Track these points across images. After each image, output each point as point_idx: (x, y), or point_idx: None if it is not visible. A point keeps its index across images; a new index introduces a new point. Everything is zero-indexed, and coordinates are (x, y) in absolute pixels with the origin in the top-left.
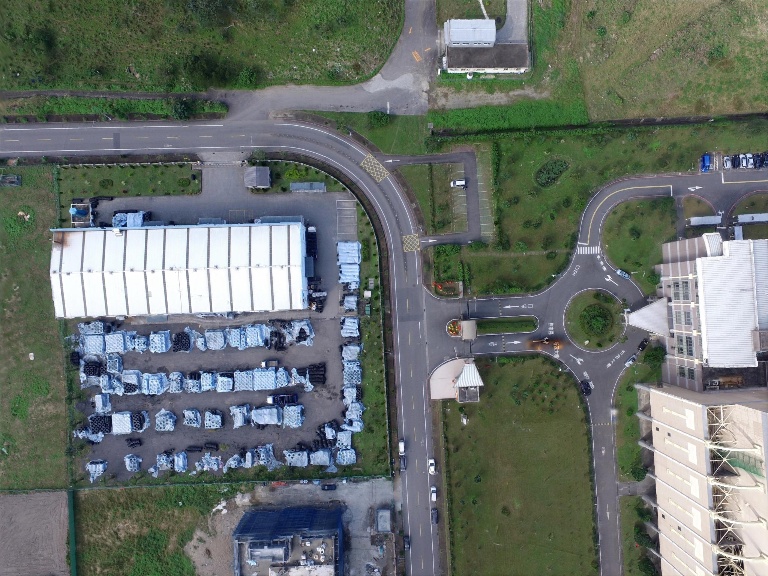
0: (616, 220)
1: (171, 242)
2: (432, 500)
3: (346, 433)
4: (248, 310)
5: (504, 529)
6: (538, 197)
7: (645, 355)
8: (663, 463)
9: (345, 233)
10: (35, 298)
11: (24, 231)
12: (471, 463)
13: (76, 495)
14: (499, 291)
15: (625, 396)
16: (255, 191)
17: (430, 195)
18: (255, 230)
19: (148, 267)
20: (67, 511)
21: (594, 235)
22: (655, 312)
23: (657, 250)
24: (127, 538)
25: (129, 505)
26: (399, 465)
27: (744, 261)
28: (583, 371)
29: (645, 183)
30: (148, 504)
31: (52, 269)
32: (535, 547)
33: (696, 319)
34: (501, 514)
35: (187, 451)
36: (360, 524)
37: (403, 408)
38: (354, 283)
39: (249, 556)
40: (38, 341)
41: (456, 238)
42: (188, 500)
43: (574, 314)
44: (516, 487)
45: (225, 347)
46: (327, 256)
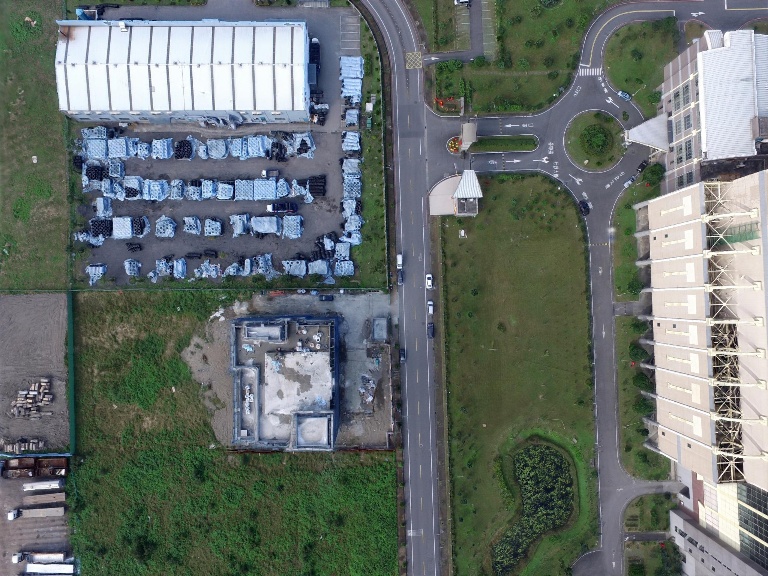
0: (618, 42)
1: (176, 39)
2: (429, 313)
3: (345, 244)
4: (250, 109)
5: (500, 345)
6: (541, 17)
7: (644, 172)
8: (660, 269)
9: (348, 48)
10: (39, 102)
11: (30, 36)
12: (468, 279)
13: (75, 297)
14: (500, 108)
15: (623, 217)
16: (260, 3)
17: (434, 12)
18: (259, 30)
19: (152, 61)
20: (66, 312)
21: (596, 57)
22: (655, 126)
23: (659, 73)
24: (125, 341)
25: (128, 309)
26: (397, 279)
27: (745, 51)
28: (582, 191)
29: (648, 7)
30: (146, 308)
31: (57, 60)
32: (530, 364)
33: (696, 118)
34: (497, 330)
35: (186, 257)
36: (356, 336)
37: (402, 223)
38: (356, 96)
39: (245, 333)
40: (41, 144)
41: (458, 56)
42: (186, 306)
43: (574, 134)
44: (512, 304)
45: (226, 157)
46: (330, 71)
